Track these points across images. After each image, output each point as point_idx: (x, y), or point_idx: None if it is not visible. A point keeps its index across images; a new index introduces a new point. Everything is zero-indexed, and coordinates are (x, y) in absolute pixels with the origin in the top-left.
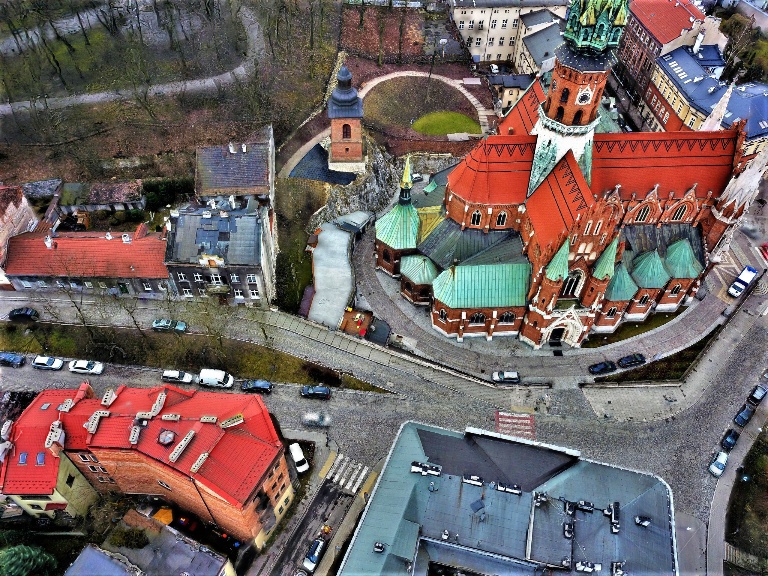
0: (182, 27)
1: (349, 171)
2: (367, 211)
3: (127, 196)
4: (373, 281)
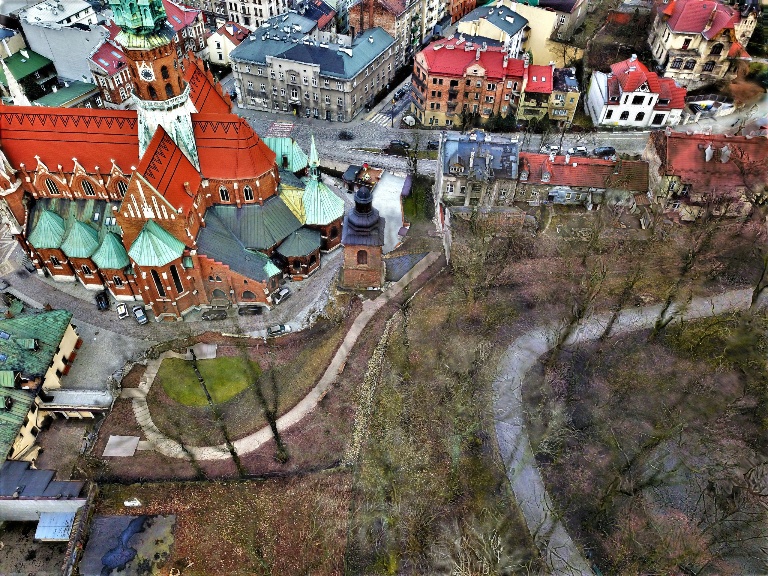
0: None
1: None
2: None
3: (589, 230)
4: None
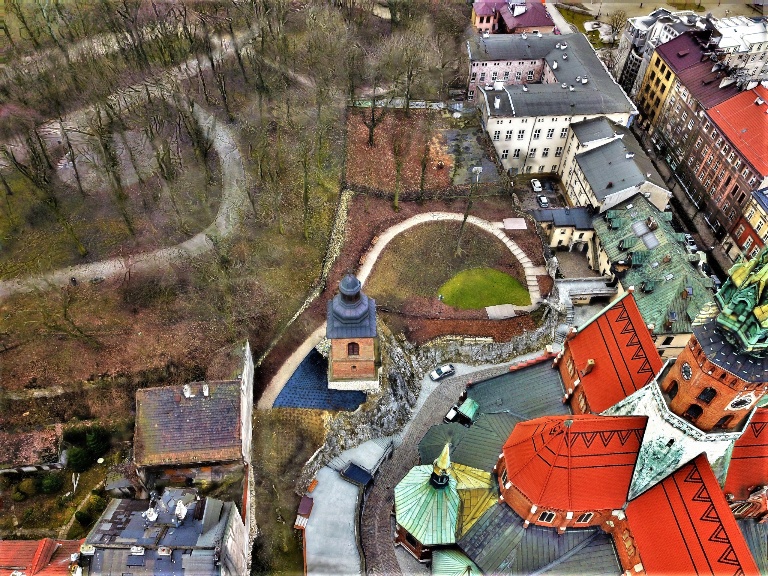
0: (135, 168)
1: (356, 389)
2: (381, 437)
3: (39, 454)
4: (391, 567)
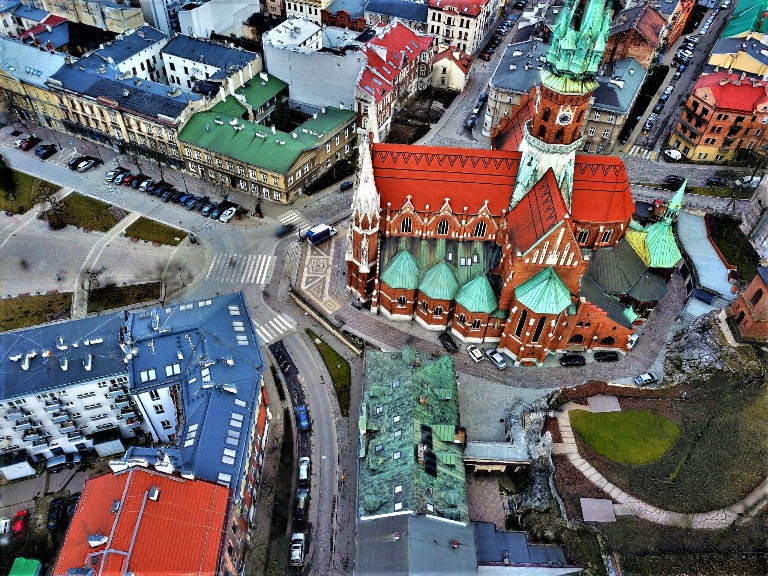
0: None
1: None
2: None
3: None
4: None
